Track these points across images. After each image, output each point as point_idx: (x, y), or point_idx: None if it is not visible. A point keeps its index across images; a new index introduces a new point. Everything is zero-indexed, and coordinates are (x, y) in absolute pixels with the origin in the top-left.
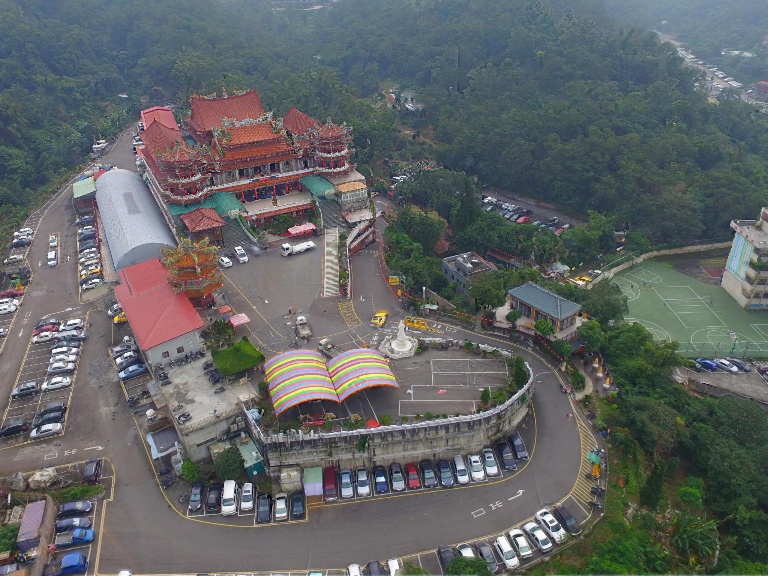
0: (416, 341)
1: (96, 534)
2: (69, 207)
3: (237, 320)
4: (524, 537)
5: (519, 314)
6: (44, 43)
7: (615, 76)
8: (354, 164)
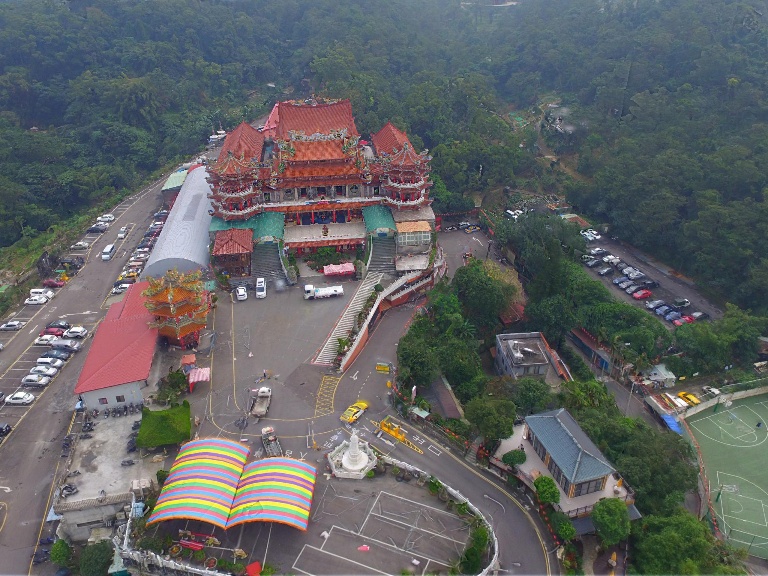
0: (374, 459)
1: None
2: (160, 197)
3: (195, 376)
4: None
5: (520, 458)
6: (205, 29)
7: None
8: (430, 199)
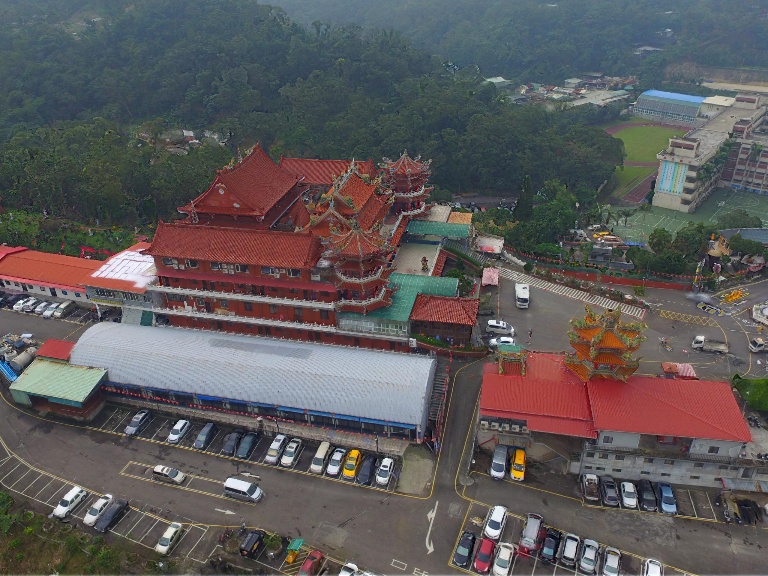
0: None
1: None
2: (46, 427)
3: (691, 370)
4: None
5: None
6: None
7: None
8: None
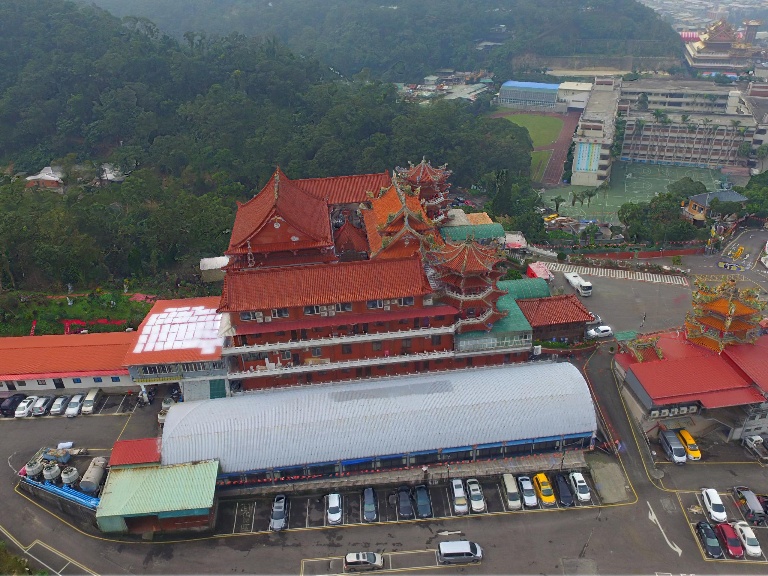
0: None
1: None
2: (164, 551)
3: None
4: None
5: None
6: None
7: None
8: None
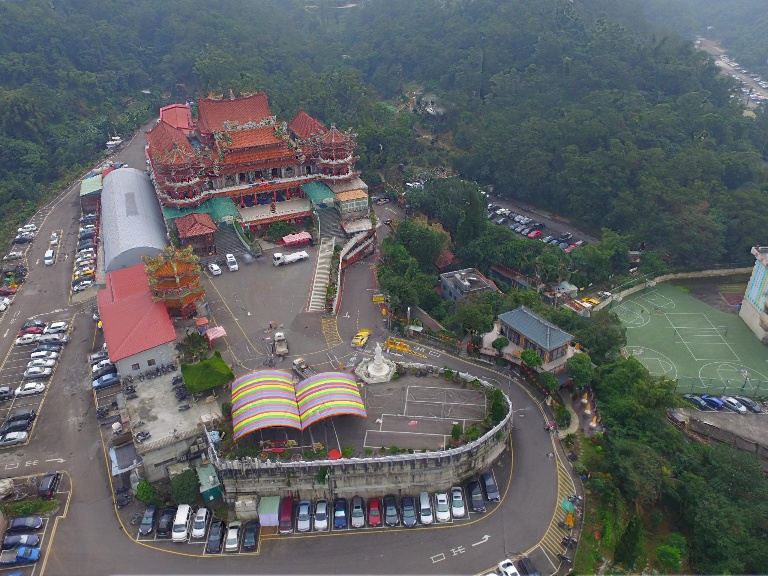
0: (394, 365)
1: (42, 553)
2: (76, 204)
3: (213, 333)
4: None
5: (506, 342)
6: (70, 38)
7: (644, 85)
8: (358, 171)
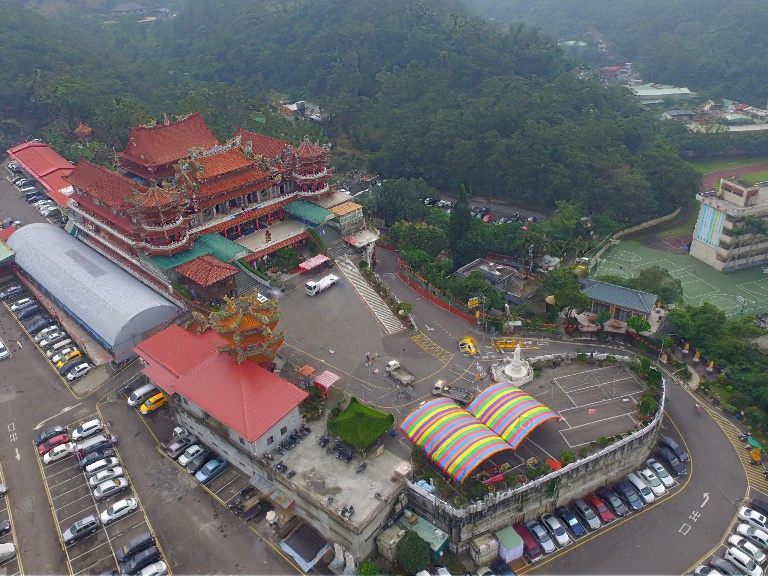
0: (527, 363)
1: None
2: None
3: (327, 380)
4: (749, 542)
5: (609, 315)
6: None
7: (515, 70)
8: (334, 183)
